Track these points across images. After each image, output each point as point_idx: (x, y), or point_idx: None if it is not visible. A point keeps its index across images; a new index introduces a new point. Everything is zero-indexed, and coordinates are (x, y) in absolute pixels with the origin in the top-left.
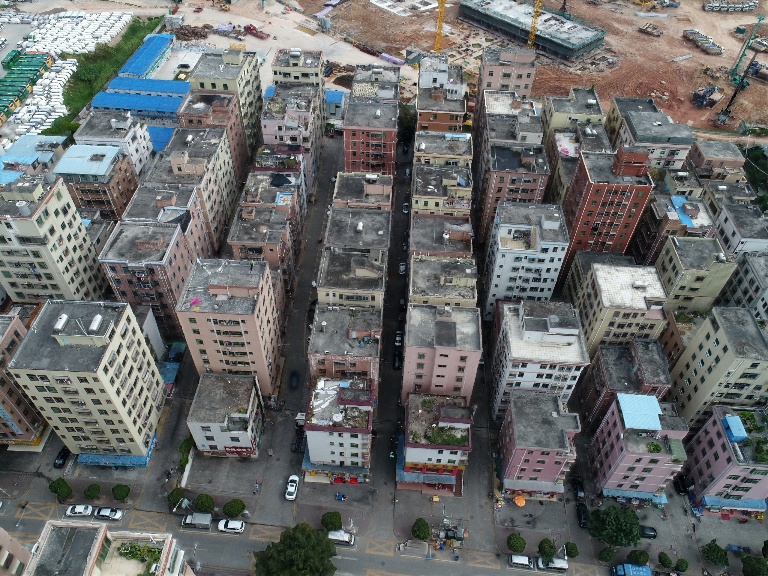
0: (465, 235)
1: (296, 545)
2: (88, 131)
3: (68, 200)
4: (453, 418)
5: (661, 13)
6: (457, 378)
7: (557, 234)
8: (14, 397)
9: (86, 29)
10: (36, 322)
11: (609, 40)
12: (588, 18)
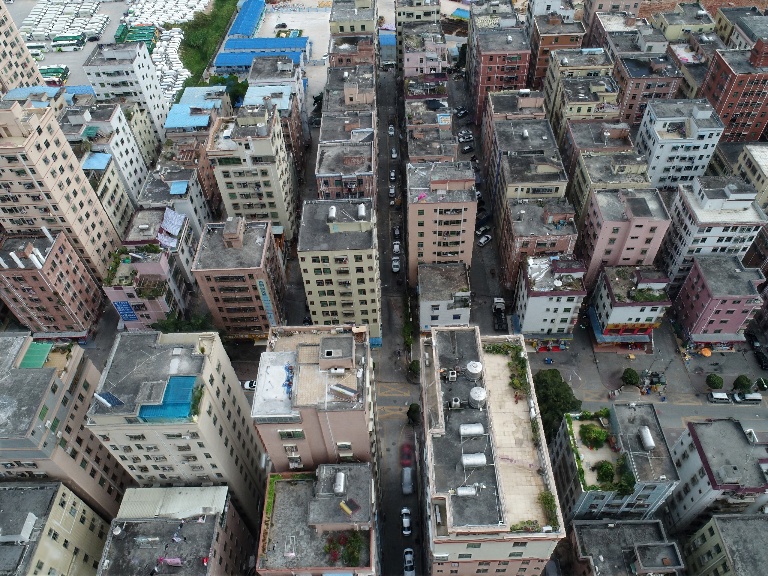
0: (623, 132)
1: (544, 386)
2: (257, 75)
3: (280, 126)
4: (653, 279)
5: None
6: (642, 251)
7: (711, 122)
8: (273, 291)
9: (179, 1)
10: (302, 218)
11: None
12: None
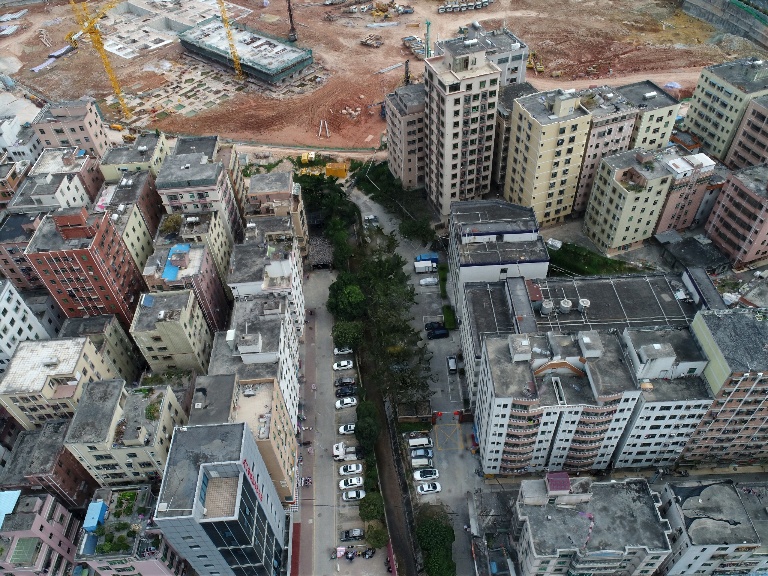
0: None
1: None
2: None
3: None
4: None
5: (393, 21)
6: None
7: None
8: None
9: None
10: None
11: (327, 58)
12: (316, 36)
